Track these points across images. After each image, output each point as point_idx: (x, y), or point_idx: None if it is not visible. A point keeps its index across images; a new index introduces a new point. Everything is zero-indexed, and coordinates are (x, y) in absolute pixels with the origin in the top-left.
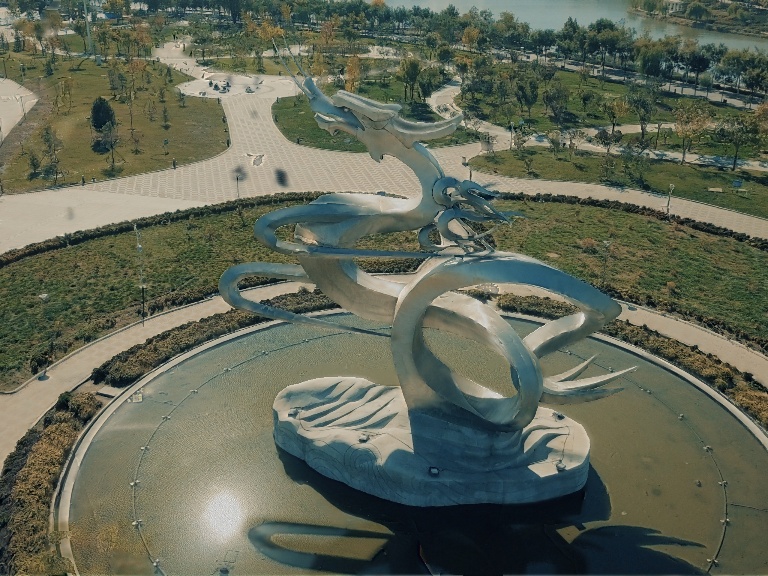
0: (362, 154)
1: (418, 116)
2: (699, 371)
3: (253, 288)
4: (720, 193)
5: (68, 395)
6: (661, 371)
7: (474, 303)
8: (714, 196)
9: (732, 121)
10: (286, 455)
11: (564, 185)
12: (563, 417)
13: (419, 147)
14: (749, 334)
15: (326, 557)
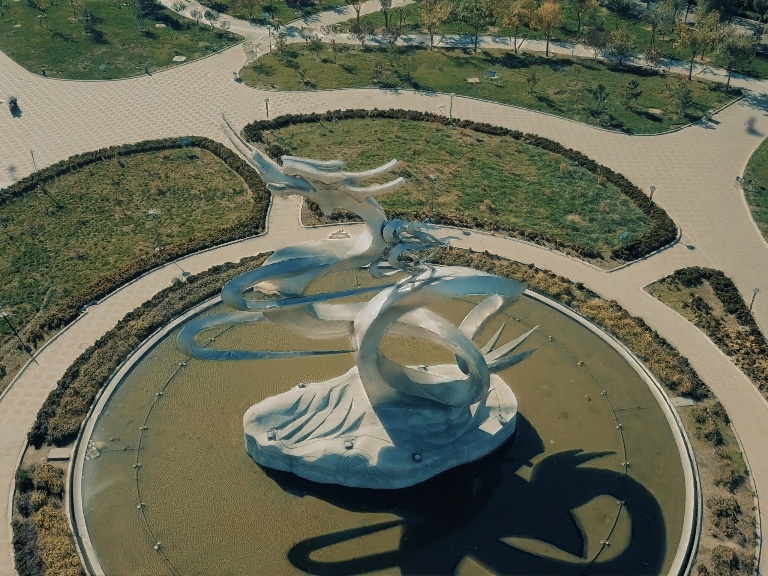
0: (125, 82)
1: (152, 15)
2: (547, 291)
3: (121, 288)
4: (479, 84)
5: (24, 473)
6: None
7: (417, 311)
8: (475, 88)
9: (471, 8)
10: (272, 472)
11: (344, 94)
12: None
13: None
14: (564, 241)
15: (364, 559)
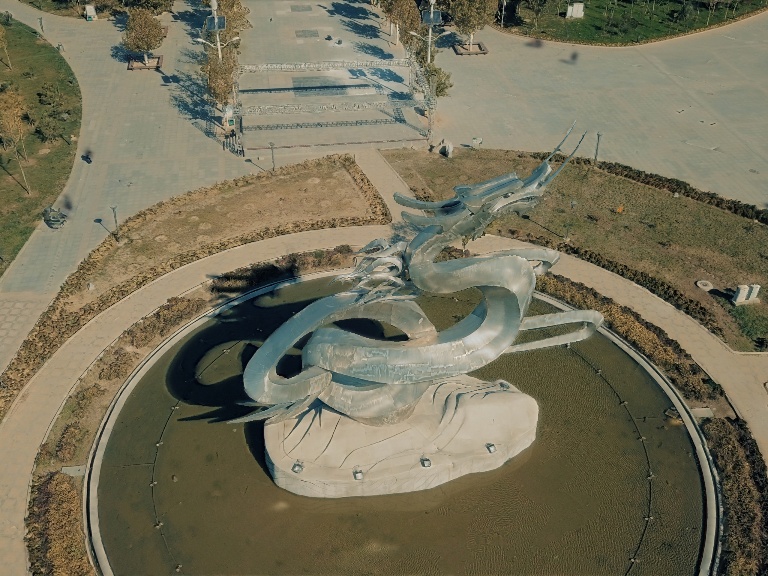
0: None
1: None
2: None
3: None
4: None
5: (716, 388)
6: None
7: (373, 345)
8: None
9: None
10: None
11: None
12: None
13: None
14: None
15: None
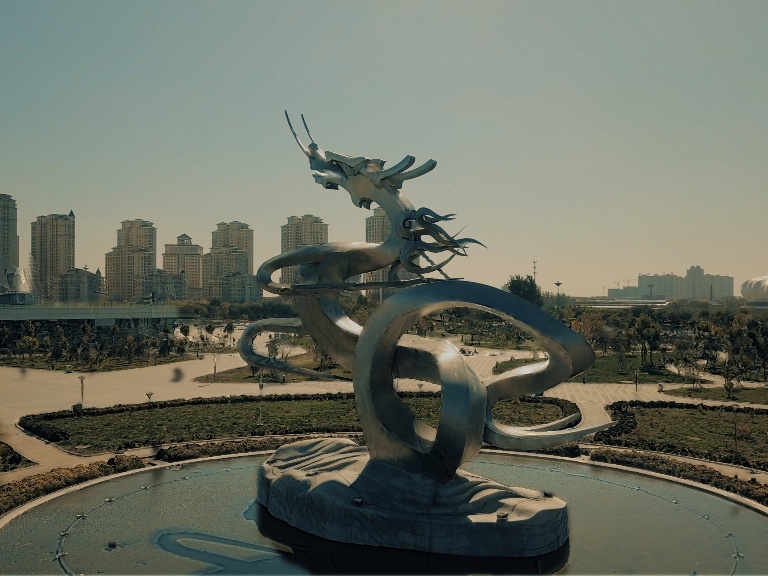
0: None
1: (645, 370)
2: None
3: (354, 432)
4: None
5: None
6: (741, 508)
7: (439, 342)
8: None
9: None
10: (257, 504)
11: (764, 406)
12: (551, 496)
13: (394, 192)
14: None
15: (211, 554)
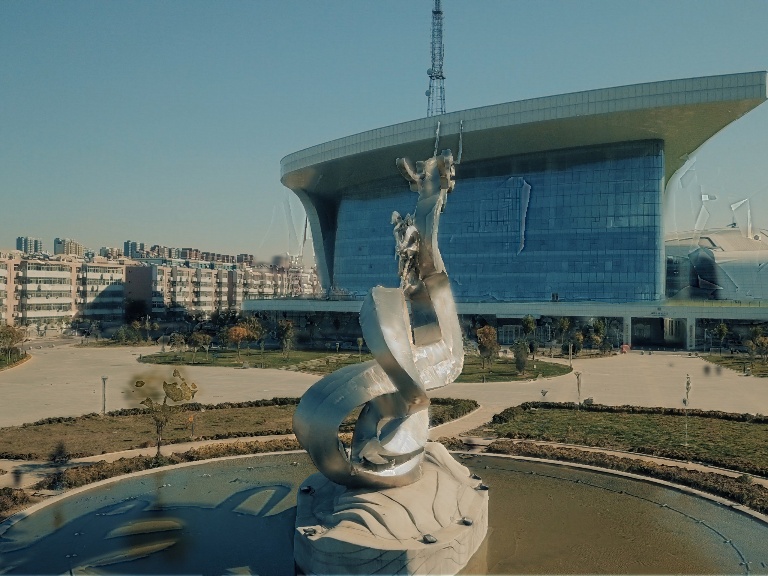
0: None
1: None
2: None
3: (739, 472)
4: None
5: None
6: None
7: None
8: None
9: None
10: None
11: None
12: (426, 542)
13: (433, 193)
14: None
15: None
